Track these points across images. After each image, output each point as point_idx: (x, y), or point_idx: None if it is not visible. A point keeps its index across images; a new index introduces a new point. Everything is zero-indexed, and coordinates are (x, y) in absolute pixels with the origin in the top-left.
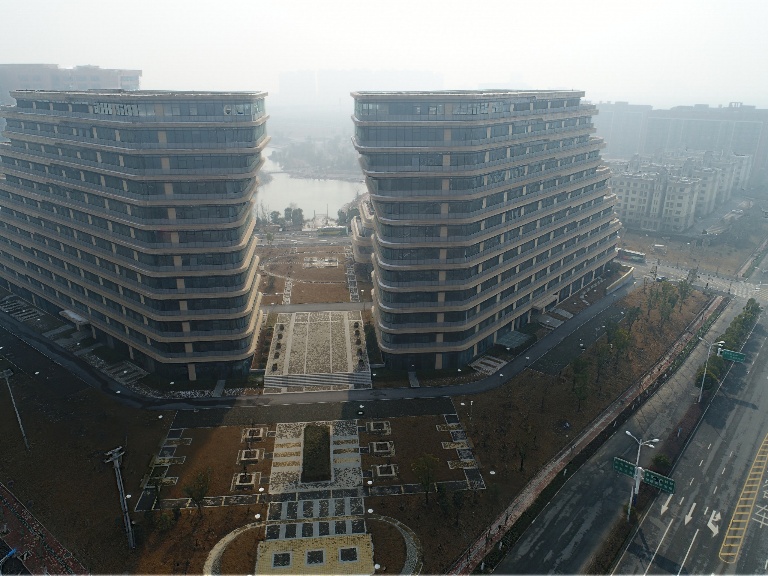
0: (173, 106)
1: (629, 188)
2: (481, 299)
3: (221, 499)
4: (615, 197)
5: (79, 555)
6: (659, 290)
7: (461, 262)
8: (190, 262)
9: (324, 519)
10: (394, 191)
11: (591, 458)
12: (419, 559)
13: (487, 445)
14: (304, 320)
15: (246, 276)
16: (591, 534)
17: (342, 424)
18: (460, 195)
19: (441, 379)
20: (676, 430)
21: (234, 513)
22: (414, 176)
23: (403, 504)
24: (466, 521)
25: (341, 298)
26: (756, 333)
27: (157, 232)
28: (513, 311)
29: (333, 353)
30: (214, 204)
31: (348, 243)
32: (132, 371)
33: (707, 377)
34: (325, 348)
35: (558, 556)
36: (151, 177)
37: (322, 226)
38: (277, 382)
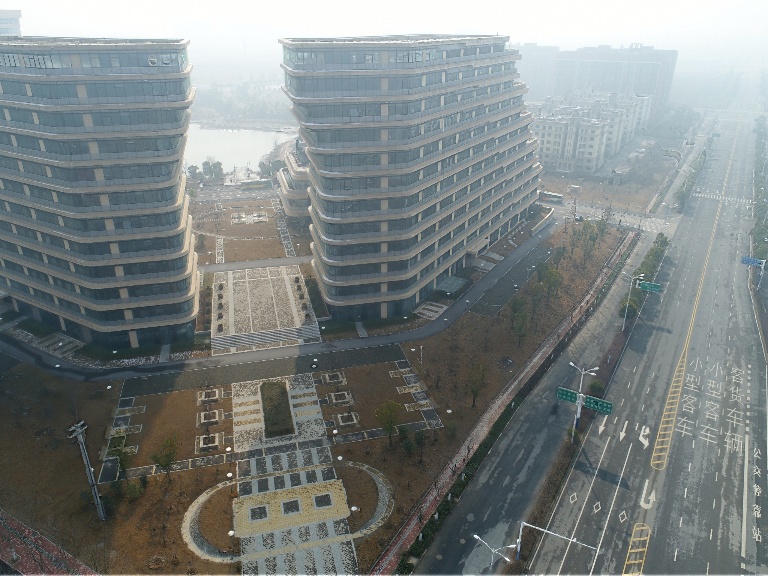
0: (91, 57)
1: (544, 131)
2: (422, 247)
3: (187, 462)
4: (536, 141)
5: (47, 533)
6: (578, 229)
7: (402, 212)
8: (123, 225)
9: (294, 471)
10: (334, 143)
11: (534, 390)
12: (390, 497)
13: (439, 386)
14: (242, 278)
15: (183, 237)
16: (541, 458)
17: (297, 378)
18: (399, 145)
19: (388, 327)
20: (605, 358)
21: (203, 474)
22: (353, 127)
23: (368, 449)
24: (429, 458)
25: (276, 253)
26: (665, 264)
27: (84, 195)
28: (450, 257)
29: (278, 309)
30: (145, 163)
31: (274, 196)
32: (66, 343)
33: (629, 308)
34: (269, 305)
35: (515, 480)
36: (73, 136)
37: (245, 180)
38: (225, 342)
